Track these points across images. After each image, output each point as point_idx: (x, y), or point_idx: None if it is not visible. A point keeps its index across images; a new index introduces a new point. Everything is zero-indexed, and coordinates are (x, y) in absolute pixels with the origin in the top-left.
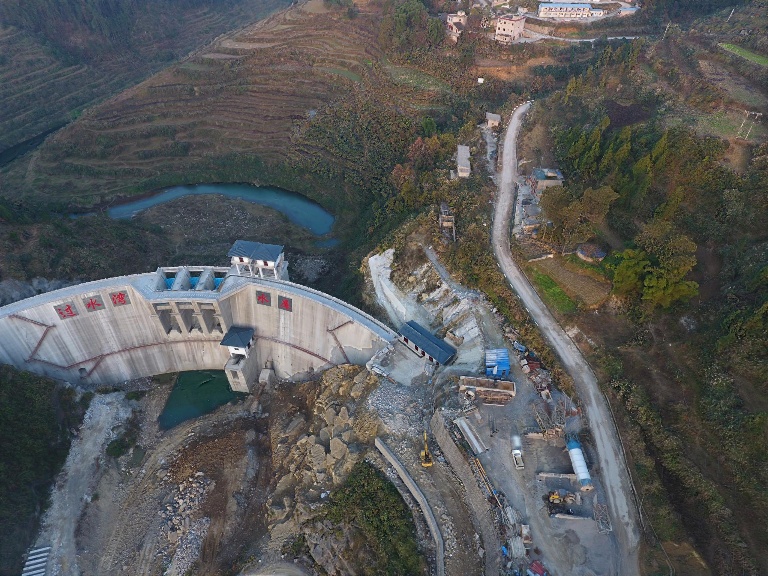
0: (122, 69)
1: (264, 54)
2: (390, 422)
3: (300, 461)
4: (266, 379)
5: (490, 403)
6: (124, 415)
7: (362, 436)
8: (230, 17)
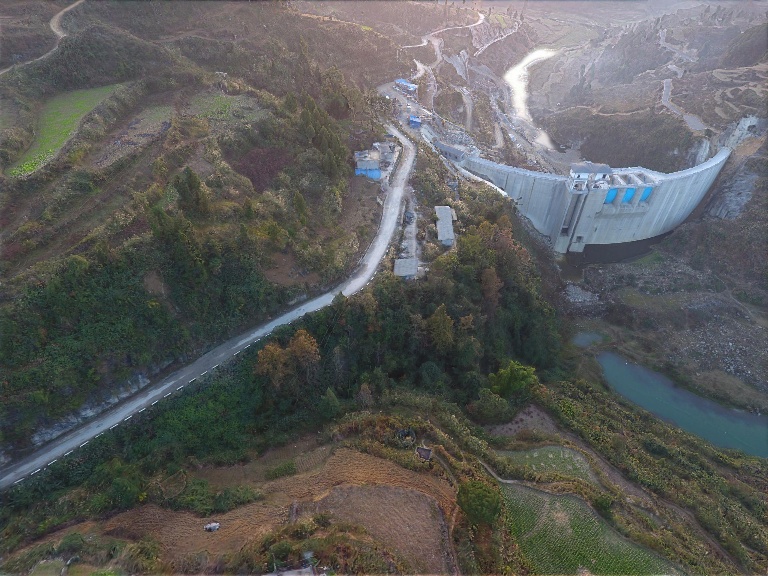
0: None
1: None
2: None
3: None
4: None
5: None
6: None
7: None
8: None
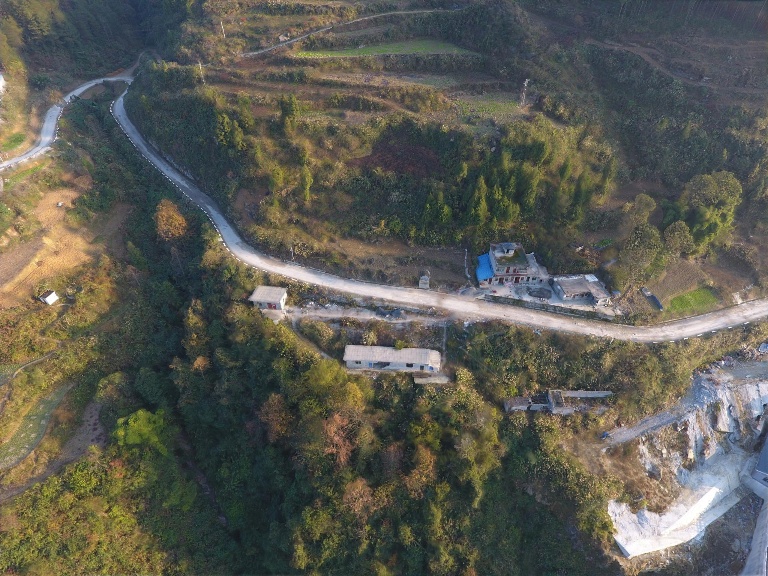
0: None
1: None
2: None
3: None
4: None
5: None
6: None
7: None
8: None
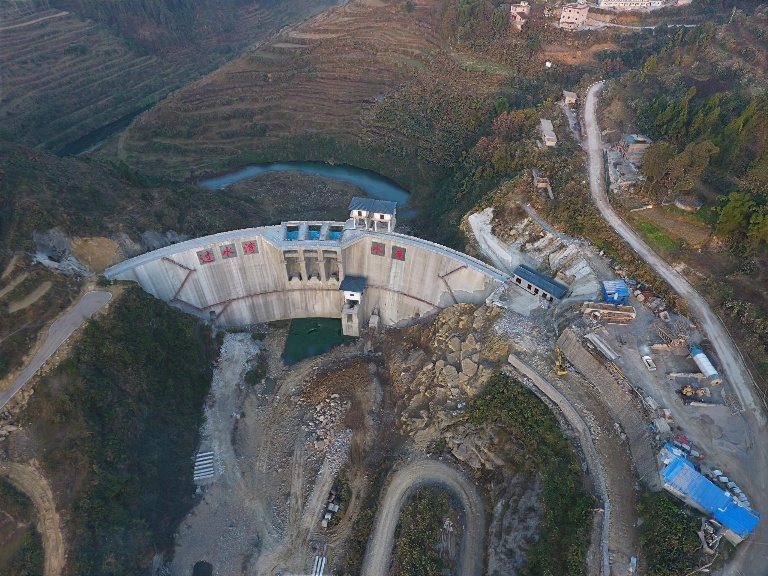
0: (187, 60)
1: (330, 44)
2: (520, 342)
3: (429, 383)
4: (376, 323)
5: (614, 323)
6: (254, 351)
7: (492, 356)
8: (278, 14)
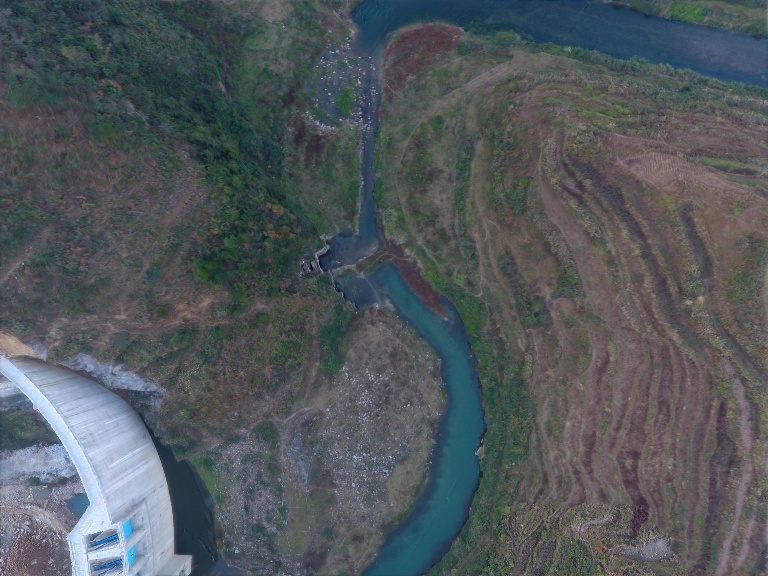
0: None
1: None
2: None
3: None
4: None
5: None
6: (64, 474)
7: None
8: None
